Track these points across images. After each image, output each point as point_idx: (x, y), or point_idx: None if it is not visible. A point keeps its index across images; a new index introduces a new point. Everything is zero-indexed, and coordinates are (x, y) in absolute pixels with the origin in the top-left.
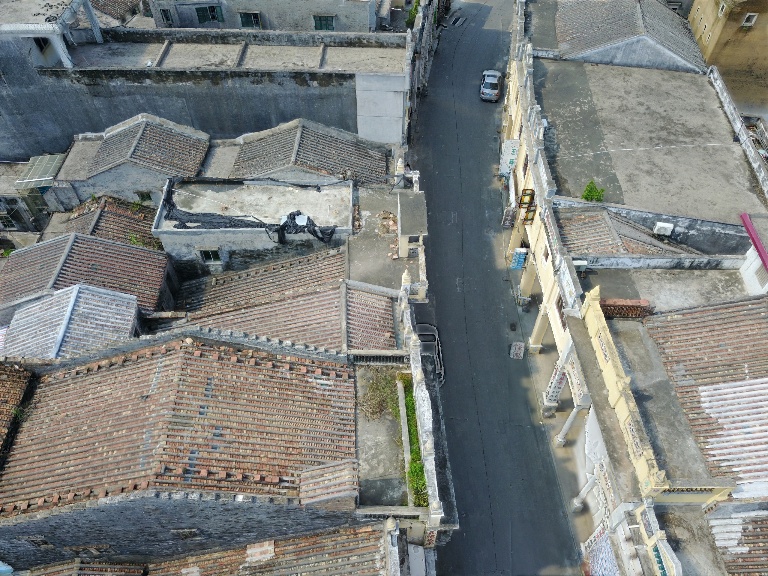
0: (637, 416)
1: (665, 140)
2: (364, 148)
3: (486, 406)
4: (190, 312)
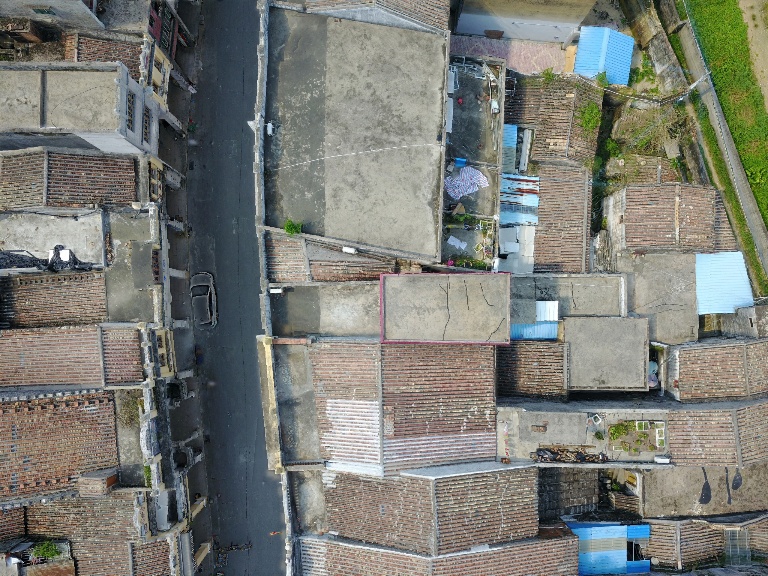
0: (276, 431)
1: (377, 141)
2: (112, 159)
3: (248, 337)
4: (8, 307)
